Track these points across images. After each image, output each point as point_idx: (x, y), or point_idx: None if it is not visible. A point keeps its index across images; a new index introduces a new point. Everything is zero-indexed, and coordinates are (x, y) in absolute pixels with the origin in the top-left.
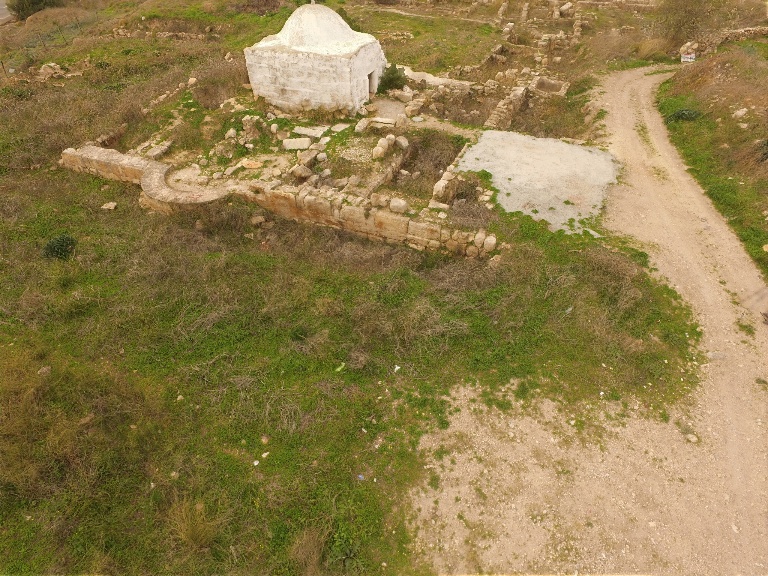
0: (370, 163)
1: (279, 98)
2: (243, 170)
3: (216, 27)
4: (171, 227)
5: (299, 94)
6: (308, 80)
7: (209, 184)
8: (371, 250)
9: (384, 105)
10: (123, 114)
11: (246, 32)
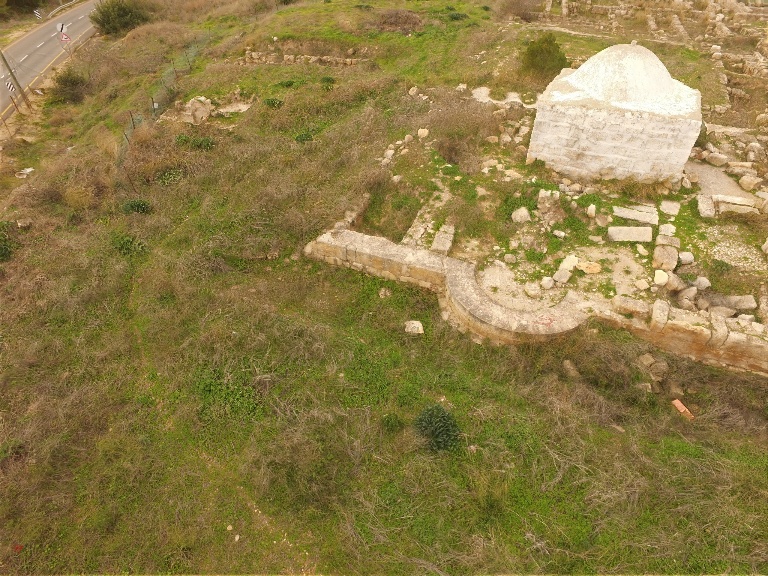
0: None
1: (568, 163)
2: (582, 276)
3: (361, 49)
4: (556, 382)
5: (603, 160)
6: (626, 145)
7: (543, 297)
8: None
9: (696, 171)
10: (367, 183)
11: (397, 55)
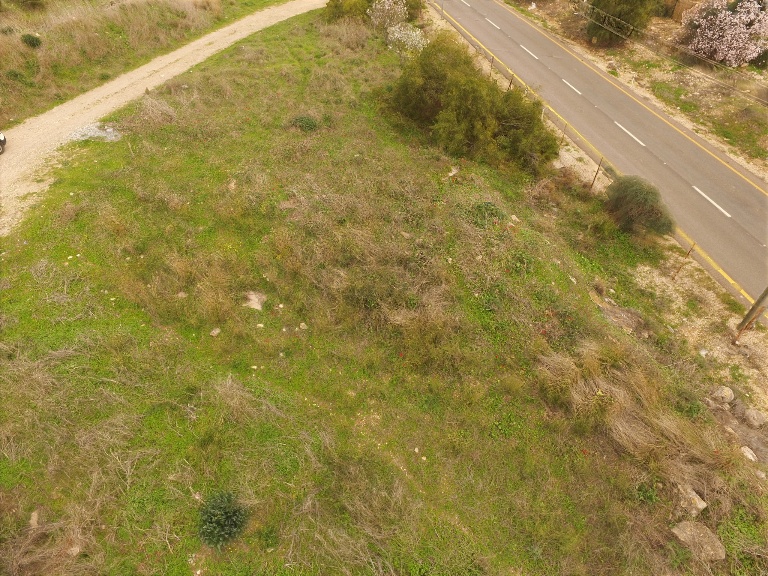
0: None
1: None
2: None
3: None
4: None
5: None
6: None
7: None
8: None
9: None
10: None
11: None
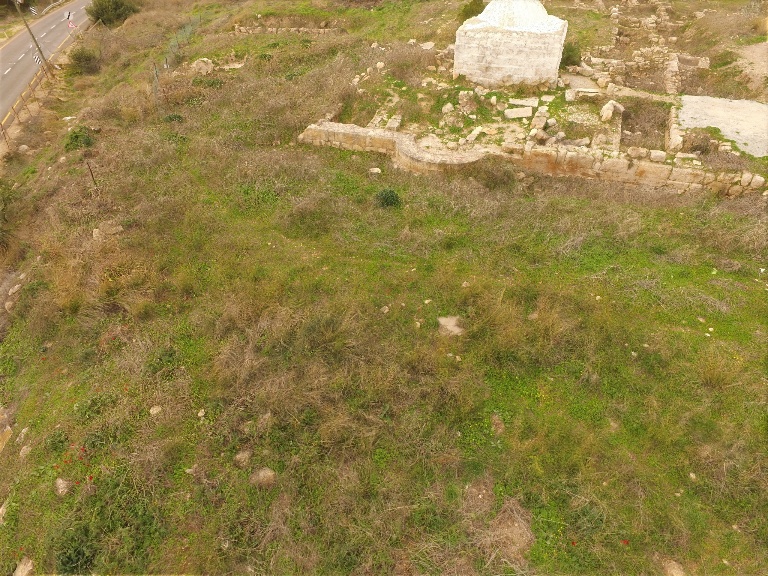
0: (602, 125)
1: (481, 75)
2: (484, 136)
3: (331, 22)
4: (461, 182)
5: (503, 70)
6: (517, 57)
7: (459, 149)
8: None
9: (571, 79)
10: (340, 94)
11: (362, 25)
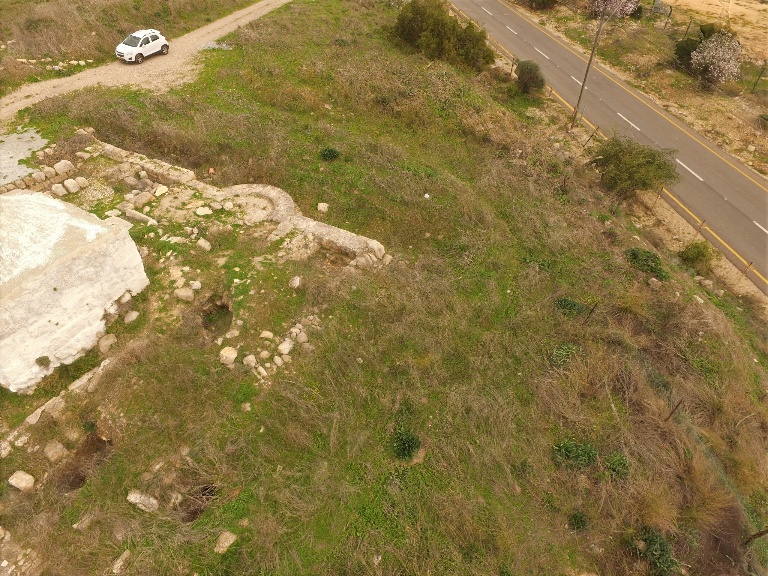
0: None
1: None
2: None
3: None
4: None
5: None
6: None
7: None
8: (148, 155)
9: None
10: None
11: None
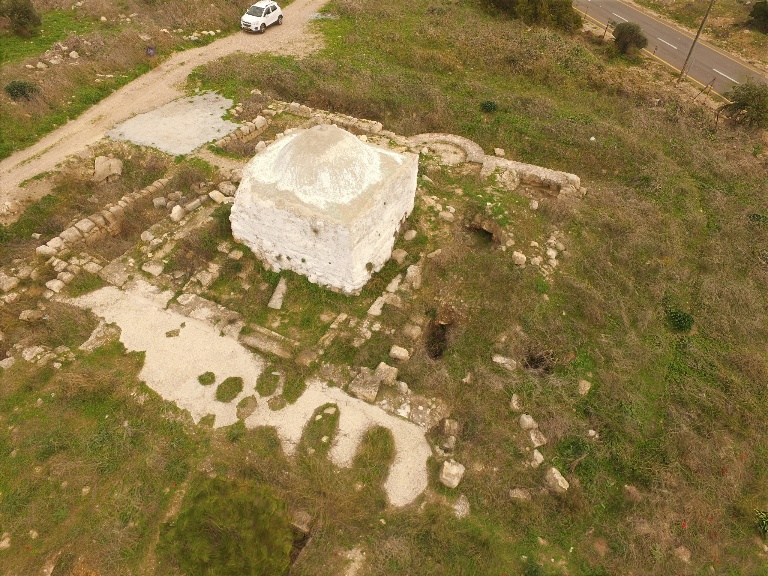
0: None
1: None
2: None
3: None
4: None
5: None
6: None
7: None
8: None
9: None
10: None
11: None
